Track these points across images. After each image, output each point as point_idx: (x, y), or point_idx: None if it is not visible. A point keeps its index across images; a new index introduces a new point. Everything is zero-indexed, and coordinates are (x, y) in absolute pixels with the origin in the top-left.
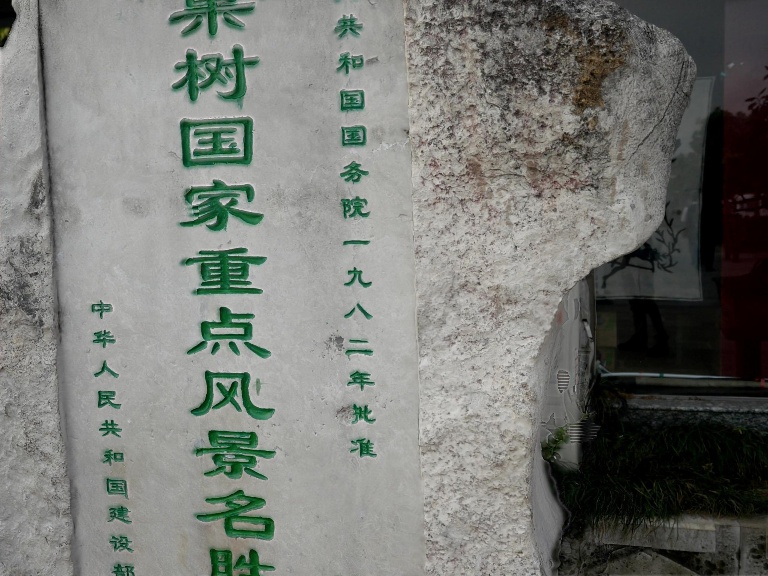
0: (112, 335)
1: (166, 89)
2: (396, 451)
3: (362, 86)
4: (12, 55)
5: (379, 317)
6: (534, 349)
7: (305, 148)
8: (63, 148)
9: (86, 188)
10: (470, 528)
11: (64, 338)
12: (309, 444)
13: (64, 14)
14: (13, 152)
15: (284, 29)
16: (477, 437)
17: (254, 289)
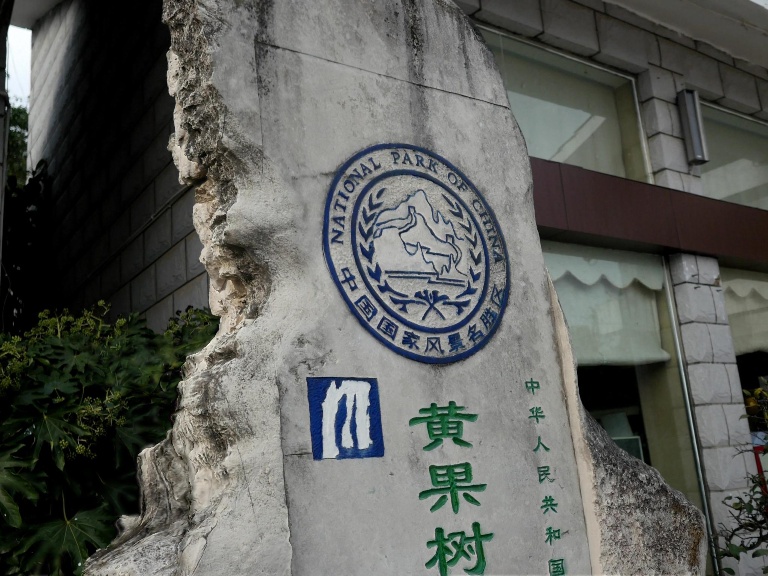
0: None
1: (420, 570)
2: None
3: (562, 556)
4: (251, 540)
5: None
6: None
7: None
8: None
9: None
10: None
11: None
12: None
13: (312, 490)
14: None
15: (509, 508)
16: None
17: None
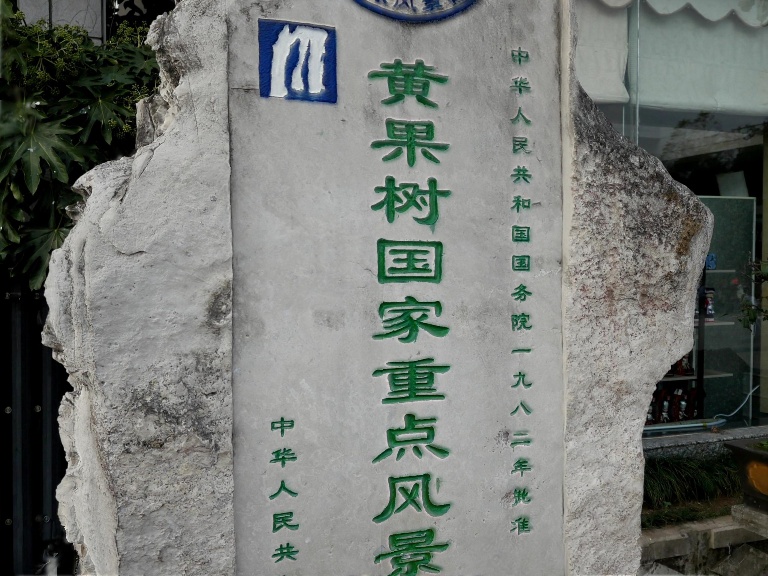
0: (293, 453)
1: (365, 210)
2: (545, 524)
3: (529, 224)
4: (192, 156)
5: (536, 412)
6: (641, 428)
7: (485, 271)
8: (248, 259)
9: (272, 301)
10: (601, 575)
11: (235, 462)
12: (478, 531)
13: (257, 123)
14: (189, 260)
15: (472, 170)
16: (607, 501)
17: (437, 396)
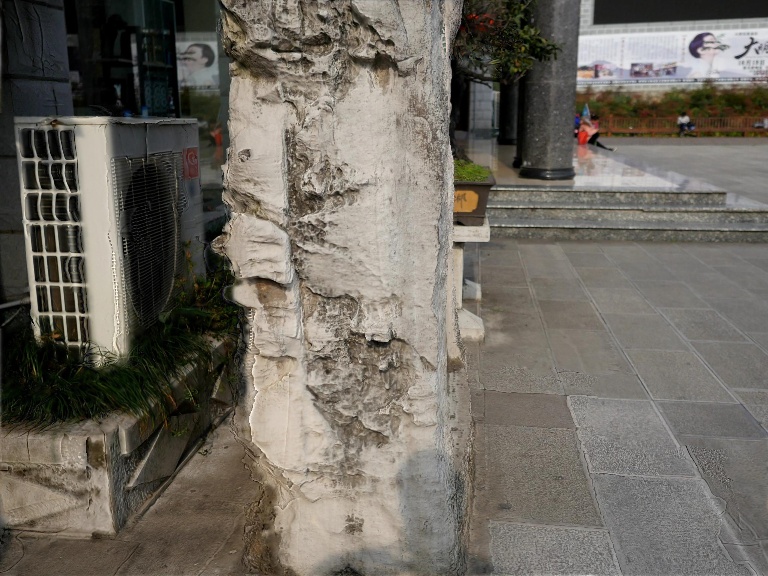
0: None
1: None
2: None
3: None
4: None
5: None
6: None
7: None
8: None
9: None
10: None
11: None
12: None
13: None
14: None
15: None
16: None
17: None
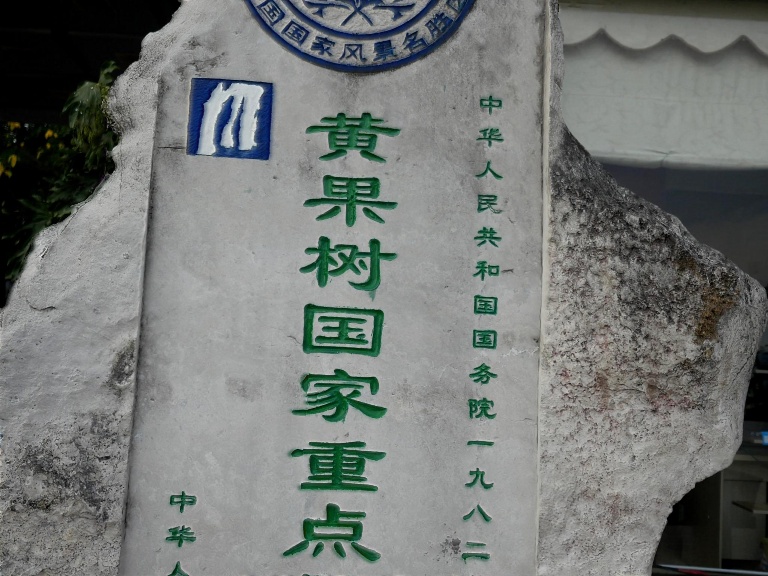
0: (192, 532)
1: (292, 272)
2: None
3: (497, 294)
4: (111, 214)
5: (498, 519)
6: (648, 555)
7: (436, 346)
8: (160, 319)
9: (182, 365)
10: None
11: (128, 534)
12: None
13: (181, 181)
14: (96, 318)
15: (424, 232)
16: None
17: (369, 486)
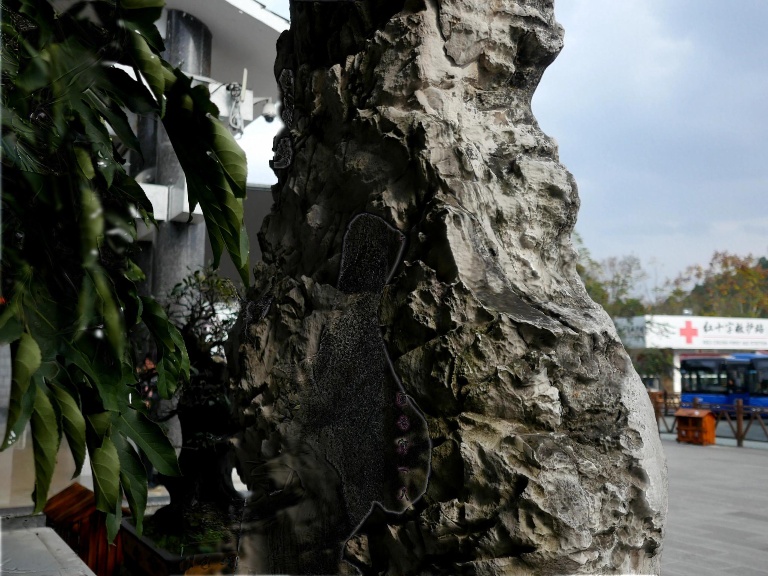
0: None
1: None
2: None
3: None
4: None
5: None
6: None
7: None
8: None
9: None
10: None
11: None
12: None
13: None
14: None
15: None
16: None
17: None
